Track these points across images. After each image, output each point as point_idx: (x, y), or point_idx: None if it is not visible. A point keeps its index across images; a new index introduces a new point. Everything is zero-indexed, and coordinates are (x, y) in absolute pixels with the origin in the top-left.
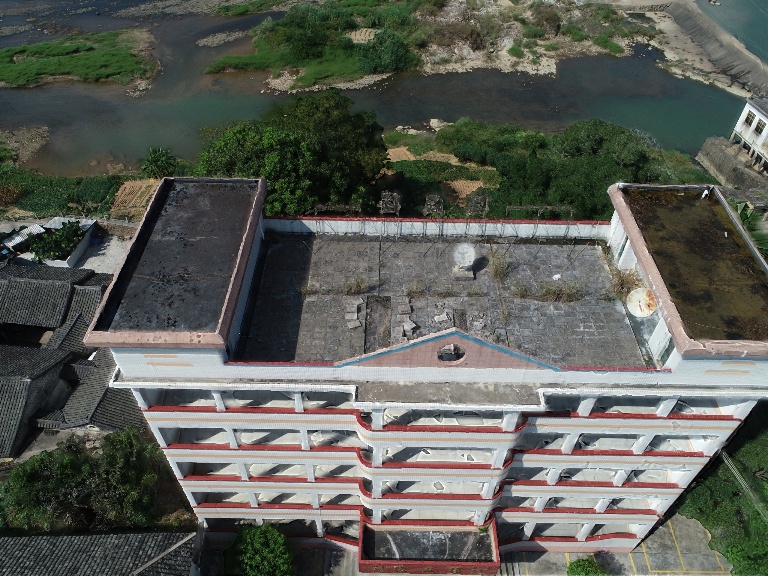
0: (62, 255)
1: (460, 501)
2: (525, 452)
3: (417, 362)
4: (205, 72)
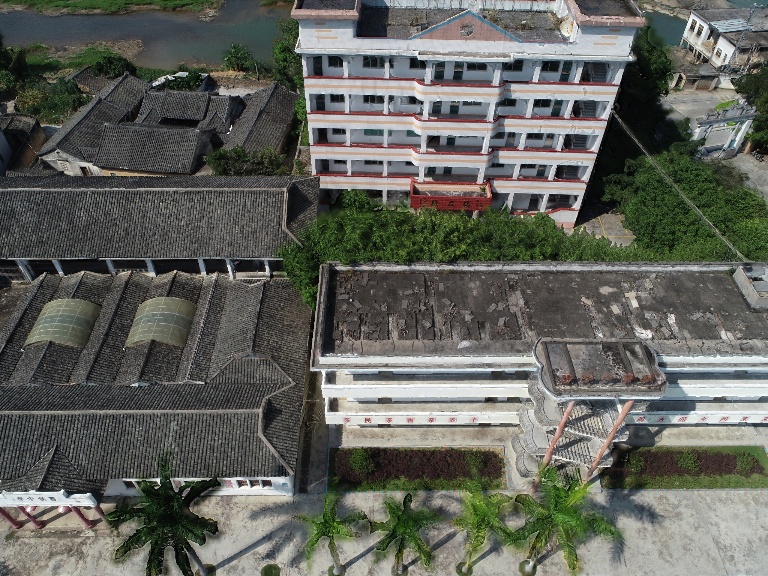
0: None
1: (470, 157)
2: (506, 117)
3: (450, 35)
4: (261, 4)
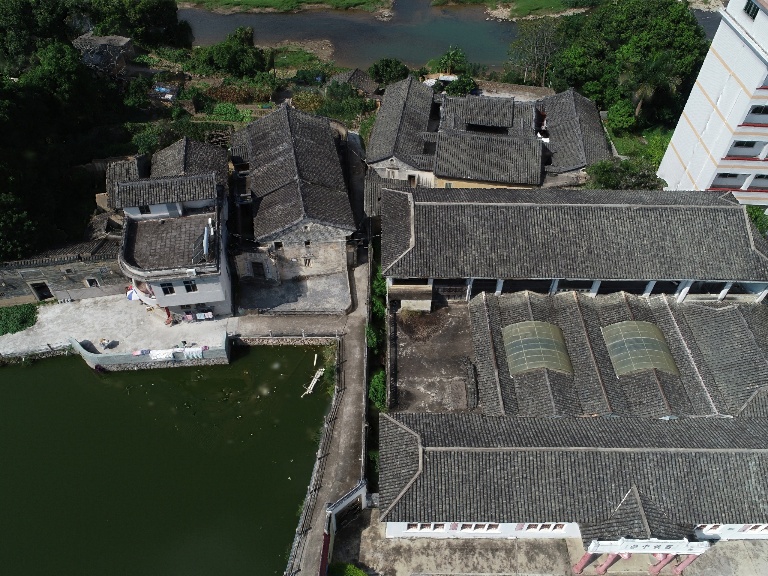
0: (465, 96)
1: None
2: None
3: None
4: (432, 4)
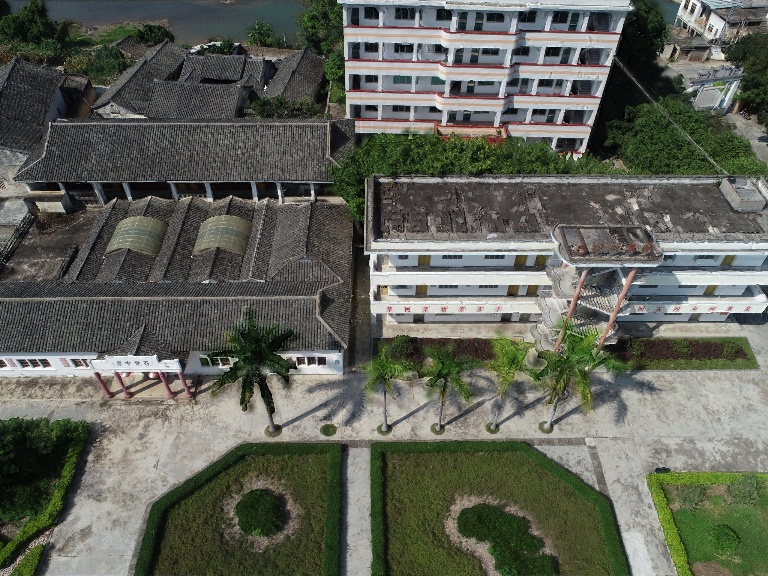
0: None
1: (488, 101)
2: (520, 64)
3: None
4: None
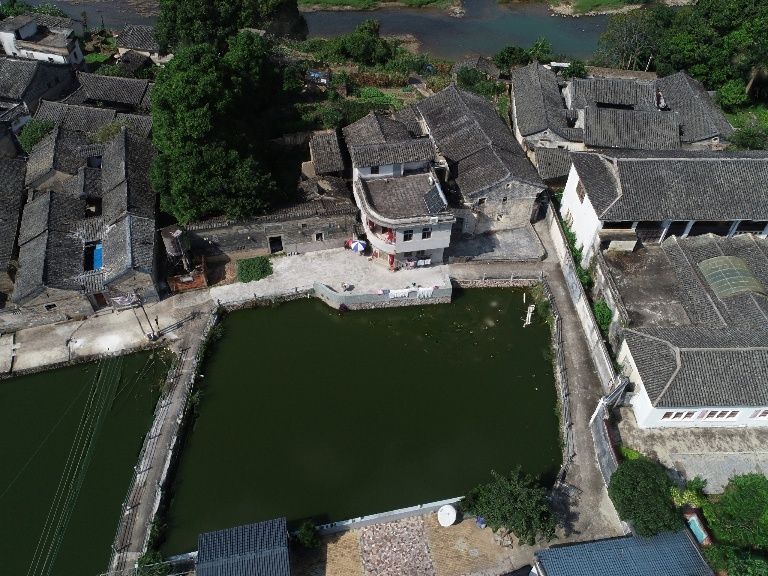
0: None
1: None
2: None
3: None
4: (498, 2)
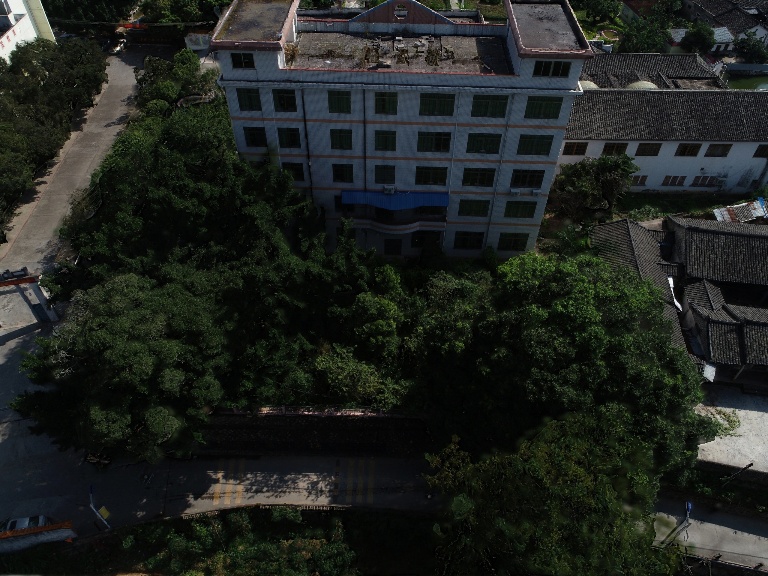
0: None
1: None
2: None
3: None
4: None
